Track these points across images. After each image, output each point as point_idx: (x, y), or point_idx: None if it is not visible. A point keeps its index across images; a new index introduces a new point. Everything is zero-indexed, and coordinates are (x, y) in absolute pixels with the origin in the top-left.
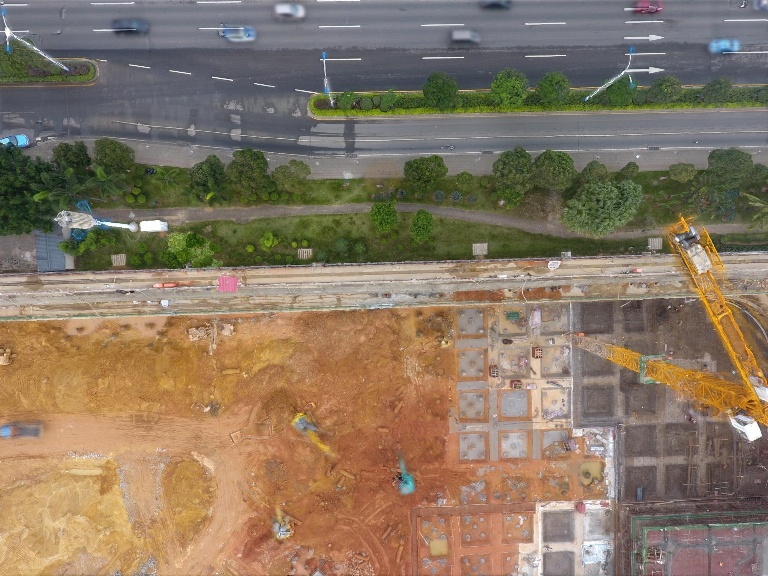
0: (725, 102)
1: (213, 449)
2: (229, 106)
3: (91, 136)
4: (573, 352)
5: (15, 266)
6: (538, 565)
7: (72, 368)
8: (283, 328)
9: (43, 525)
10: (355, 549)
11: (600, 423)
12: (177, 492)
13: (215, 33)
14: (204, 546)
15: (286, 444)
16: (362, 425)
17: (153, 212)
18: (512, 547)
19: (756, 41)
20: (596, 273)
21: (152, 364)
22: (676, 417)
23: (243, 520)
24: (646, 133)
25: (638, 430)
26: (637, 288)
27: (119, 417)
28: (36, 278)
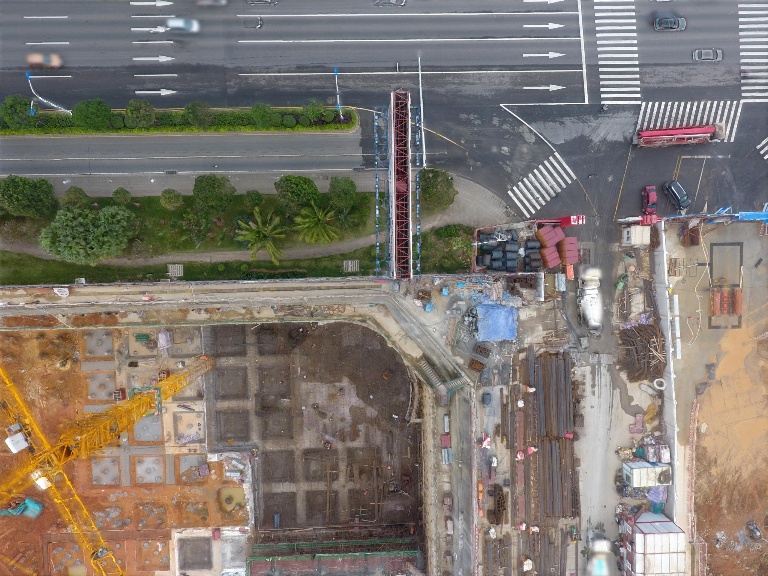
0: (237, 125)
1: None
2: None
3: None
4: (205, 375)
5: None
6: None
7: None
8: None
9: None
10: None
11: (235, 448)
12: None
13: None
14: None
15: None
16: None
17: None
18: (148, 574)
19: (273, 63)
20: (108, 301)
21: None
22: (315, 442)
23: None
24: (159, 157)
25: (279, 455)
26: (198, 314)
27: None
28: None
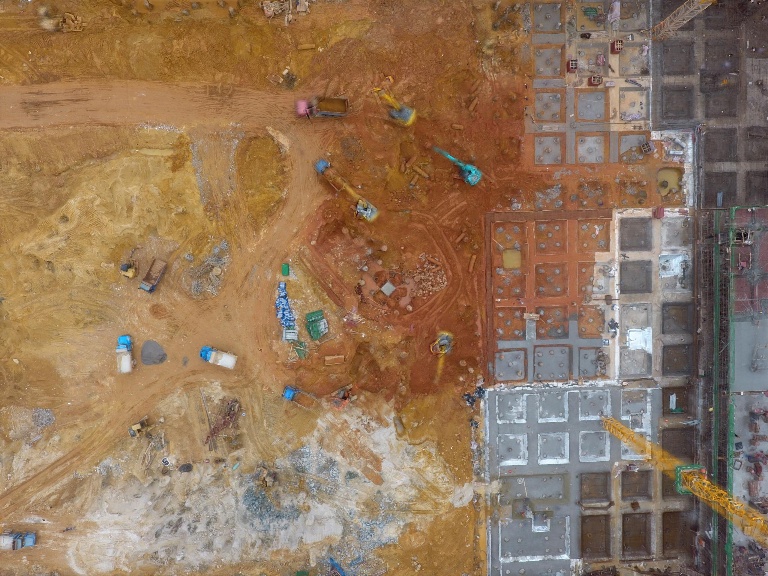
0: None
1: (288, 125)
2: None
3: None
4: (652, 49)
5: None
6: (614, 275)
7: (145, 32)
8: (358, 9)
9: (114, 200)
10: (428, 252)
11: (679, 125)
12: (250, 172)
13: None
14: (277, 230)
15: (363, 121)
16: (438, 112)
17: None
18: (588, 256)
19: None
20: None
21: (227, 31)
22: (757, 121)
23: (318, 203)
24: None
25: (717, 136)
26: None
27: (192, 88)
28: None
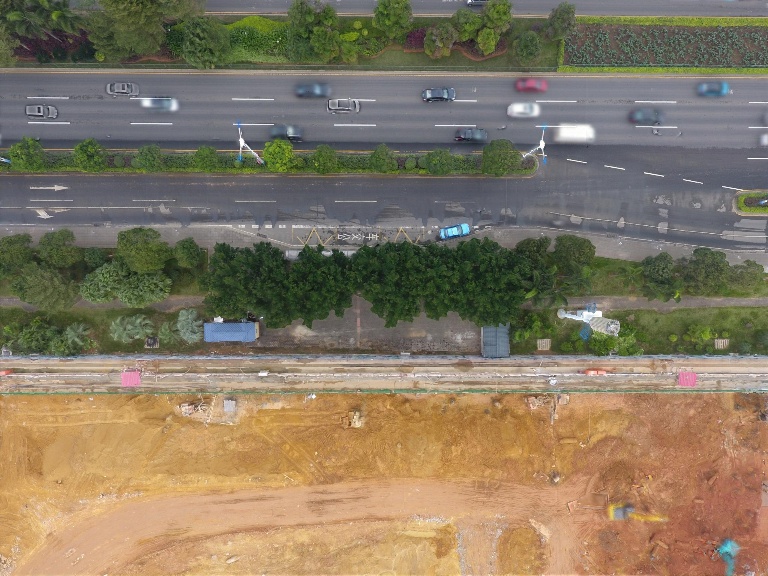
0: None
1: (550, 517)
2: (658, 200)
3: (526, 226)
4: None
5: (446, 348)
6: None
7: (423, 434)
8: (614, 399)
9: None
10: None
11: None
12: (510, 558)
13: (650, 131)
14: None
15: (621, 515)
16: (687, 497)
17: (580, 300)
18: None
19: None
20: None
21: (498, 432)
22: None
23: None
24: None
25: None
26: None
27: (462, 483)
28: (467, 360)
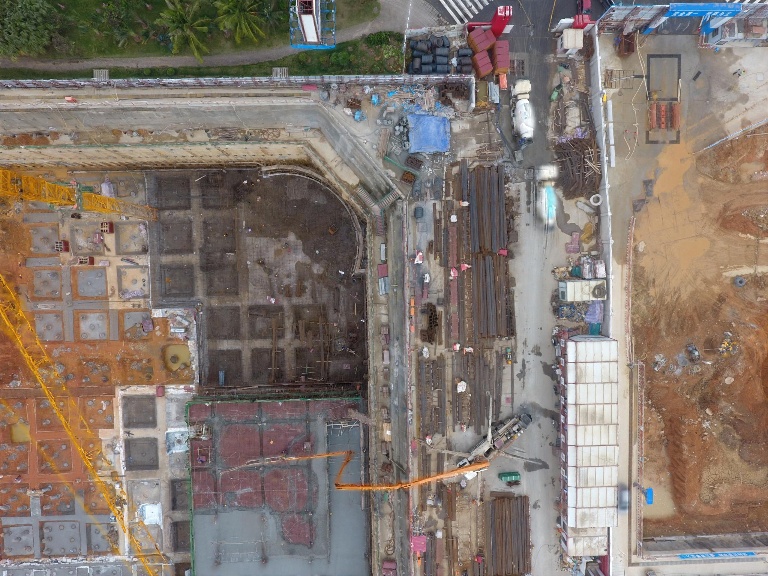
0: None
1: None
2: None
3: None
4: (149, 228)
5: None
6: (120, 452)
7: None
8: None
9: None
10: None
11: (179, 303)
12: None
13: None
14: None
15: None
16: None
17: None
18: None
19: None
20: None
21: None
22: (261, 299)
23: None
24: None
25: (224, 313)
26: (131, 137)
27: None
28: None
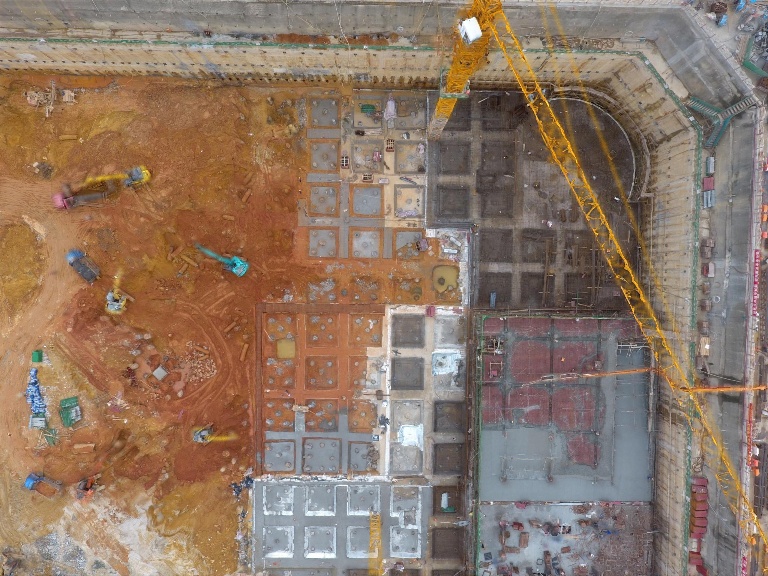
0: None
1: (45, 214)
2: None
3: None
4: (428, 148)
5: None
6: (386, 371)
7: None
8: (127, 100)
9: None
10: (196, 341)
11: (454, 224)
12: (7, 258)
13: None
14: (32, 316)
15: (120, 213)
16: (203, 205)
17: None
18: (360, 350)
19: None
20: None
21: None
22: (534, 222)
23: (73, 291)
24: None
25: None
26: None
27: None
28: None
